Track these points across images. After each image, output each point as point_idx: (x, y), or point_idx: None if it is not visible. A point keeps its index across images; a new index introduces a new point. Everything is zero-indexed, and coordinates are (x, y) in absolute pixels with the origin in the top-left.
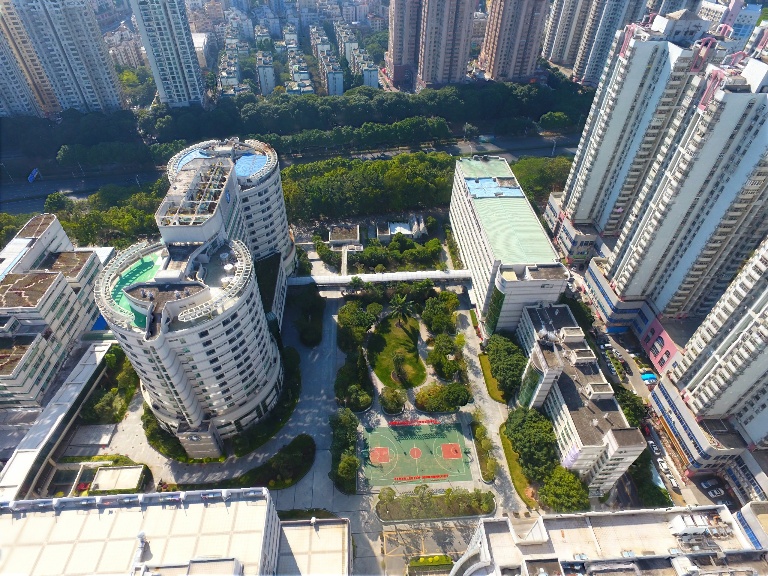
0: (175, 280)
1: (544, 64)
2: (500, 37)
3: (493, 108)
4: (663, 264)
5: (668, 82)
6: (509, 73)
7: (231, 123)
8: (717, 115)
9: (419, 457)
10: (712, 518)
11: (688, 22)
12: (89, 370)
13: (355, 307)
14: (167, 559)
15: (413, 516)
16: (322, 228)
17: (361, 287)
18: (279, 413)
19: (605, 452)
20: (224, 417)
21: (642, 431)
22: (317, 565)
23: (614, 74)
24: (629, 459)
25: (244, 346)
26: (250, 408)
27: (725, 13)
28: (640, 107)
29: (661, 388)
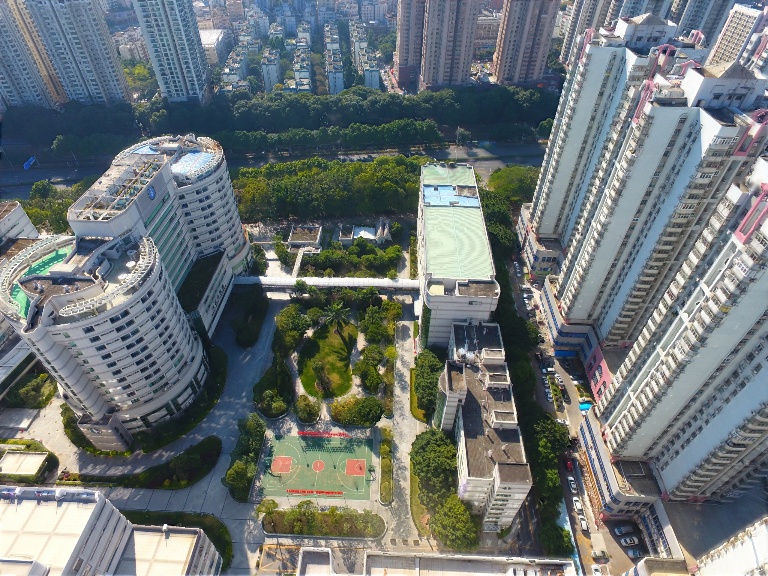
0: (69, 274)
1: (559, 68)
2: (506, 39)
3: (491, 113)
4: (607, 288)
5: (623, 92)
6: (514, 77)
7: (223, 119)
8: (645, 130)
9: (321, 470)
10: (555, 575)
11: (650, 27)
12: (22, 354)
13: (293, 310)
14: None
15: (295, 531)
16: (289, 228)
17: (306, 290)
18: (193, 412)
19: (493, 486)
20: (128, 412)
21: (564, 465)
22: (155, 574)
23: (574, 81)
24: (518, 496)
25: (143, 344)
26: (157, 405)
27: (759, 18)
28: (601, 117)
29: (587, 421)
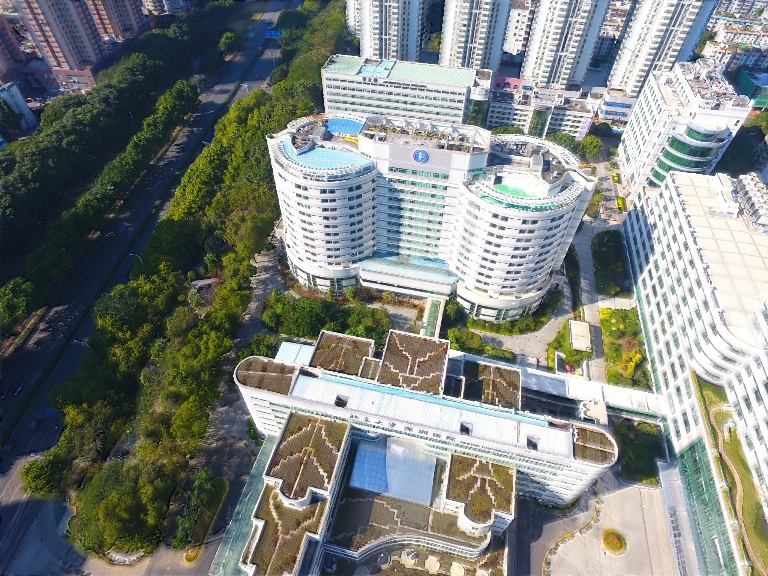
0: None
1: None
2: None
3: (176, 58)
4: None
5: None
6: (133, 24)
7: None
8: None
9: None
10: None
11: None
12: None
13: None
14: (714, 206)
15: None
16: None
17: None
18: None
19: None
20: None
21: None
22: None
23: None
24: None
25: None
26: None
27: None
28: None
29: None
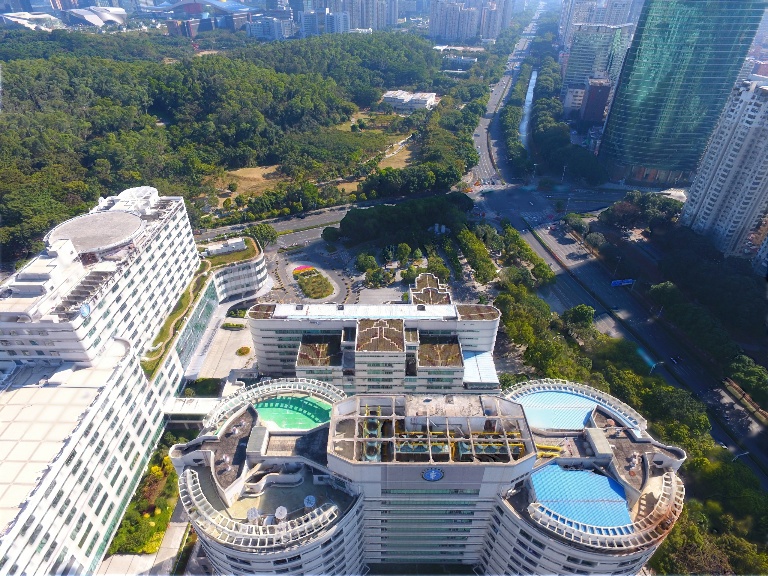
0: None
1: None
2: None
3: None
4: None
5: None
6: None
7: None
8: None
9: None
10: None
11: None
12: None
13: None
14: None
15: None
16: None
17: None
18: None
19: None
20: None
21: None
22: None
23: None
24: None
25: None
26: None
27: None
28: None
29: None
